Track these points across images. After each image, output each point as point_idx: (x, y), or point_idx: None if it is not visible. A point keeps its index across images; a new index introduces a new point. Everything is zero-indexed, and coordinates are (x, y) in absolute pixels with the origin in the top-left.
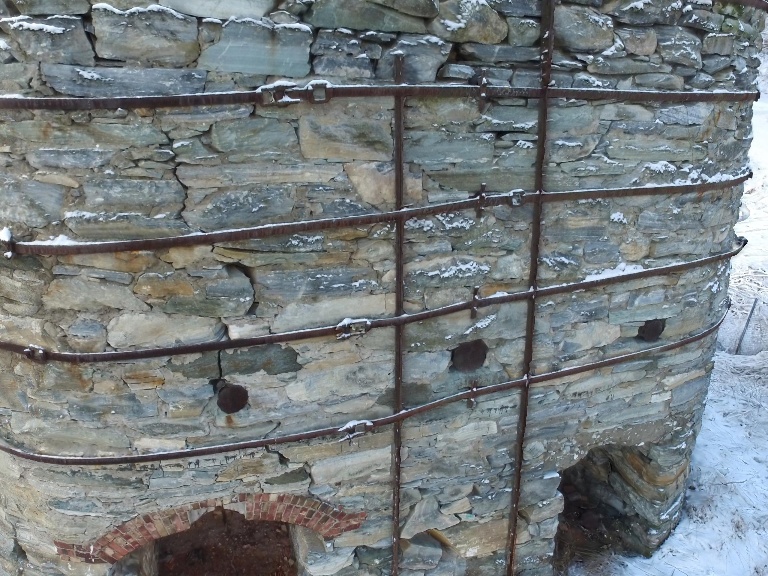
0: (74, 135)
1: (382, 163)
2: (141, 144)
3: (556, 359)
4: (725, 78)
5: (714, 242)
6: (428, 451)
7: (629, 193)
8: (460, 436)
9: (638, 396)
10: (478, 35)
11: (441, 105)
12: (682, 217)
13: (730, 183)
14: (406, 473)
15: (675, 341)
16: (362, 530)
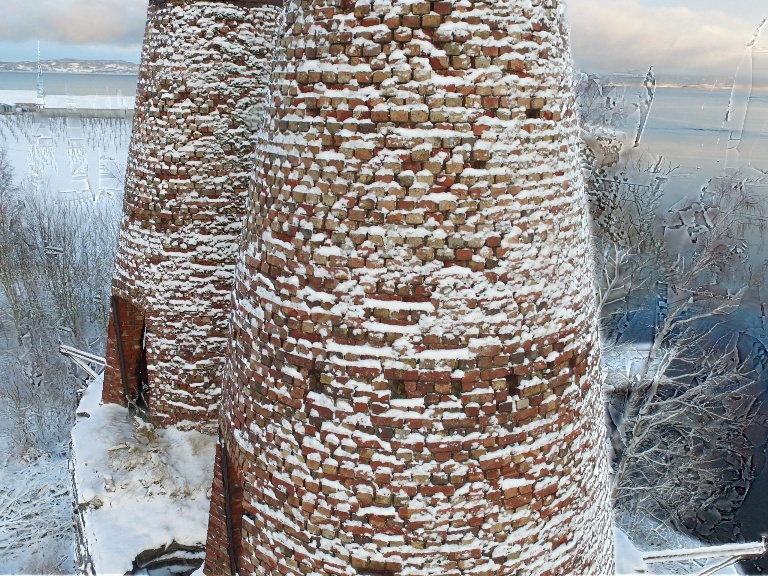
0: None
1: None
2: None
3: None
4: None
5: None
6: None
7: None
8: None
9: None
10: None
11: None
12: None
13: None
14: None
15: None
16: None
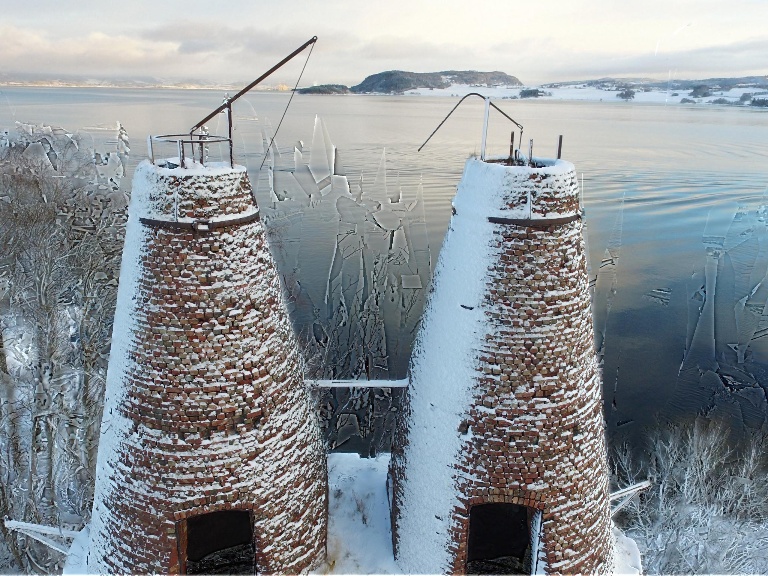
0: (498, 572)
1: None
2: (478, 570)
3: None
4: None
5: None
6: None
7: None
8: None
9: None
10: None
11: None
12: None
13: None
14: None
15: None
16: None
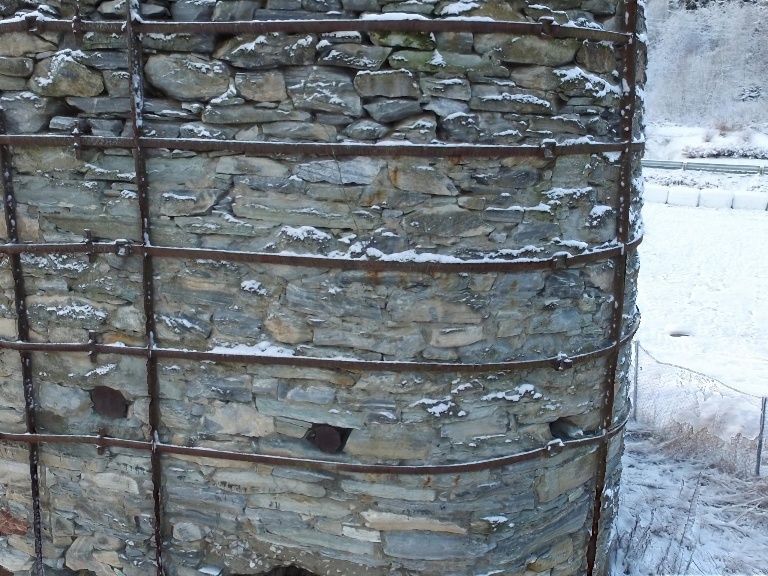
0: None
1: (0, 202)
2: None
3: (195, 434)
4: (405, 126)
5: (431, 344)
6: (73, 485)
7: (257, 259)
8: (100, 482)
9: (320, 519)
10: (73, 89)
11: (44, 153)
12: (344, 299)
13: (445, 267)
14: (58, 500)
15: (365, 463)
16: (26, 539)
